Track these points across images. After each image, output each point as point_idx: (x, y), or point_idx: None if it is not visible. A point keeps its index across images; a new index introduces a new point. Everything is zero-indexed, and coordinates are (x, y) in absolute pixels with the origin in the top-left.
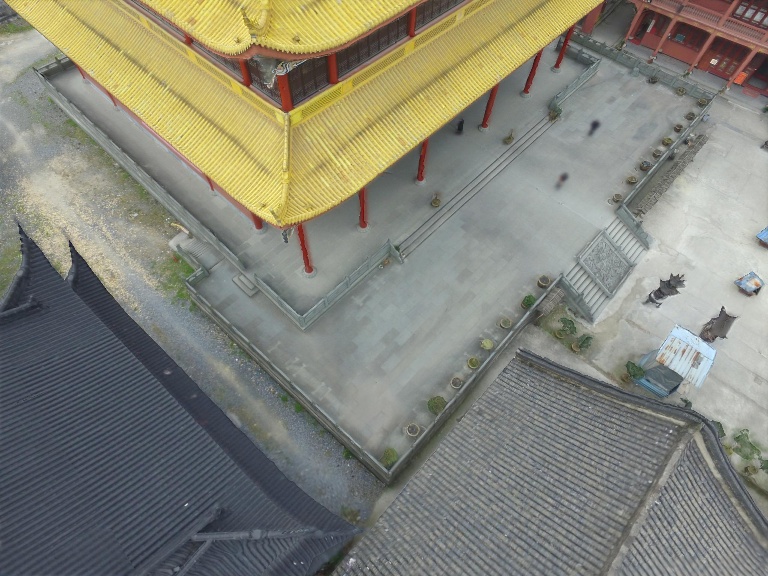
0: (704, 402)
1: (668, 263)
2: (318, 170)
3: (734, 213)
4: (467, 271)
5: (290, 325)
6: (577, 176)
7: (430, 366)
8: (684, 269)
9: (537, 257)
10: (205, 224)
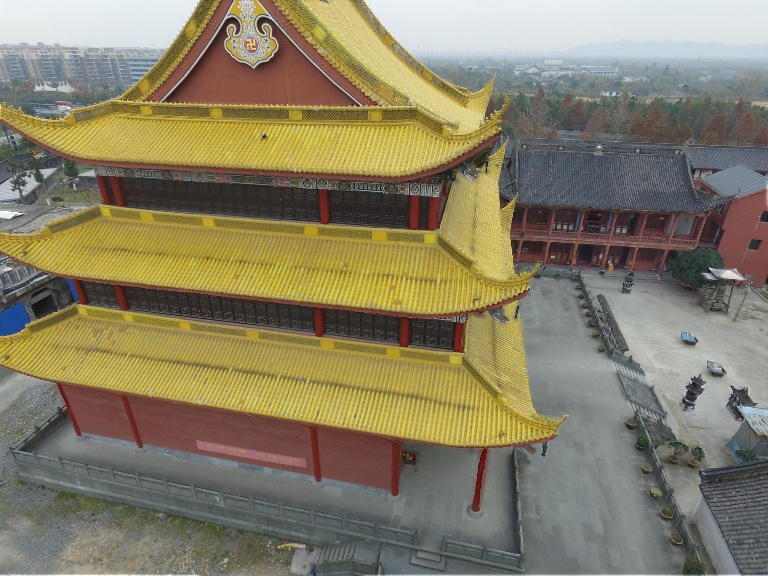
0: None
1: (663, 378)
2: (501, 390)
3: (655, 333)
4: (577, 444)
5: None
6: (564, 345)
7: (642, 539)
8: (675, 377)
9: (605, 409)
10: None
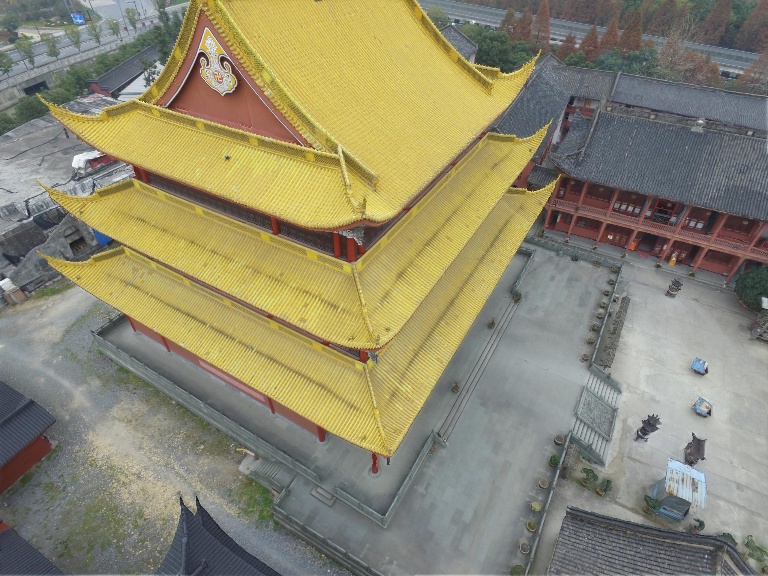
0: (710, 517)
1: (639, 402)
2: (392, 399)
3: (668, 351)
4: (498, 443)
5: (372, 526)
6: (550, 344)
7: (498, 537)
8: (652, 404)
9: (546, 419)
10: (275, 446)
